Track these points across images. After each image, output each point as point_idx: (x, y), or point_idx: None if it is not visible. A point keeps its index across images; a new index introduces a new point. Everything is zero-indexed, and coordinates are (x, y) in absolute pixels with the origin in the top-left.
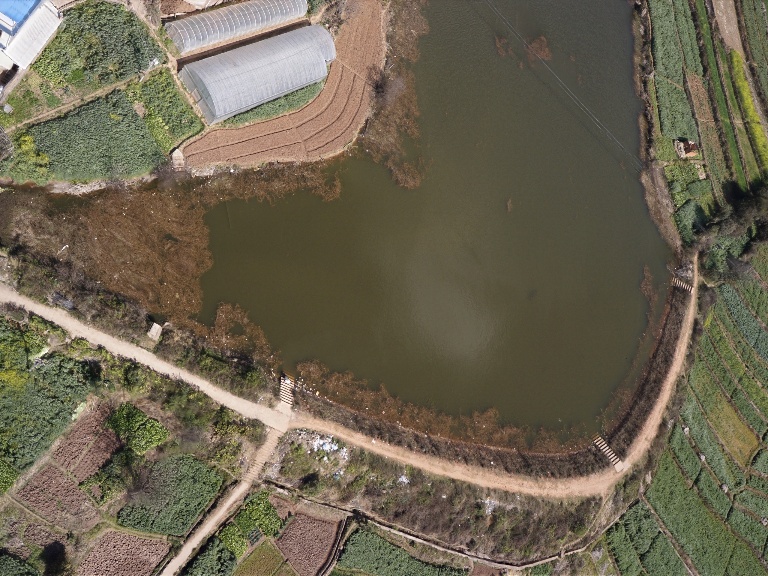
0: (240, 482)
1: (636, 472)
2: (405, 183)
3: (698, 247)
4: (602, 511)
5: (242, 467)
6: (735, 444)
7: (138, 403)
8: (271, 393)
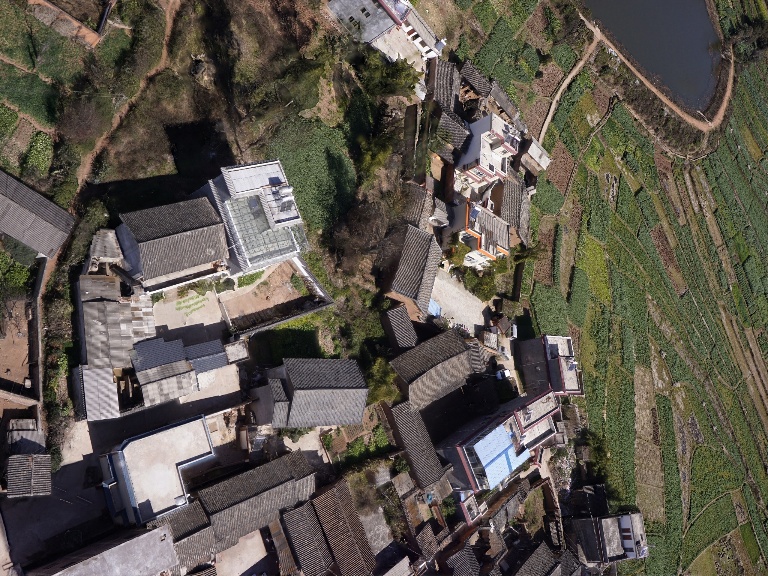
0: (581, 60)
1: (716, 131)
2: None
3: (733, 40)
4: (704, 142)
5: None
6: (752, 149)
7: (552, 8)
8: None
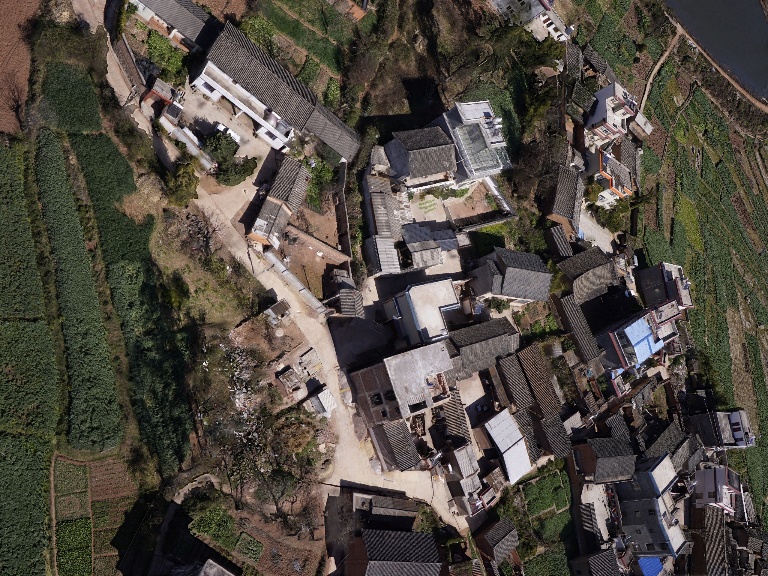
0: (667, 51)
1: None
2: None
3: None
4: None
5: (668, 44)
6: None
7: (642, 7)
8: None
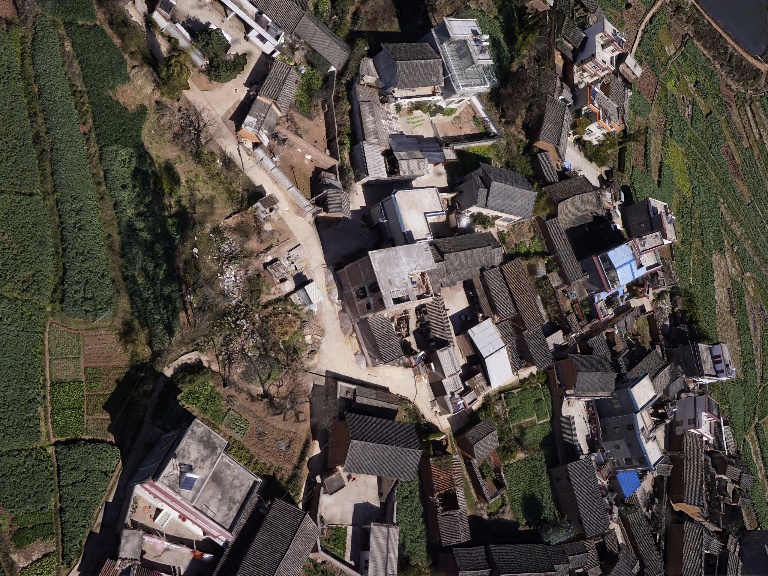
0: (659, 0)
1: None
2: None
3: None
4: (762, 79)
5: None
6: None
7: None
8: None
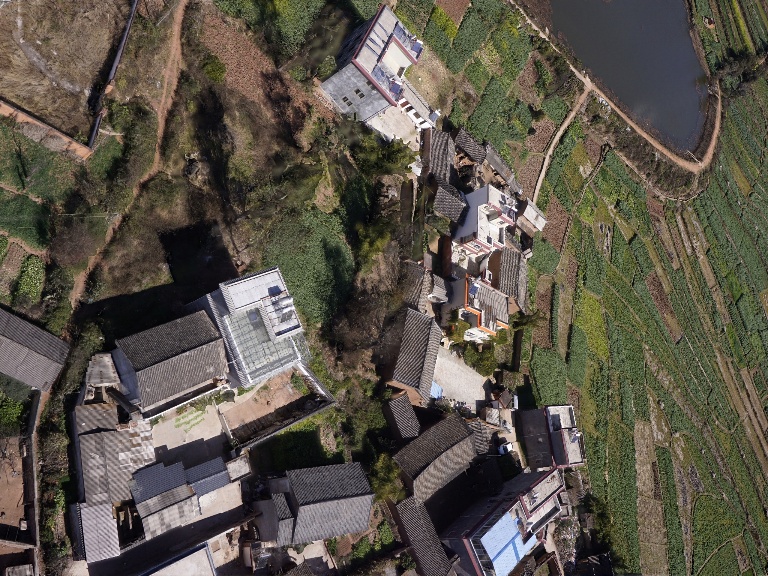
0: (573, 110)
1: (706, 171)
2: (605, 0)
3: (720, 75)
4: (695, 182)
5: None
6: (741, 184)
7: (542, 61)
8: (583, 72)
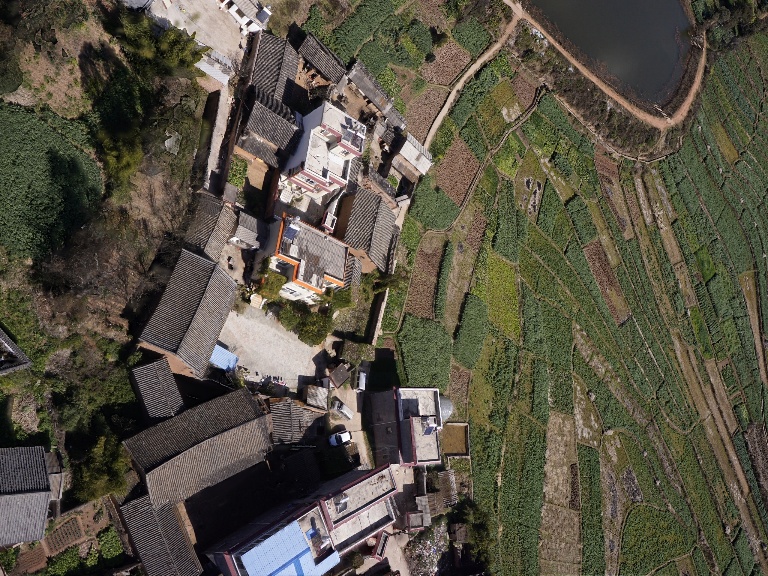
0: (497, 42)
1: (677, 129)
2: None
3: (707, 25)
4: (660, 141)
5: (500, 32)
6: (725, 150)
7: None
8: None
